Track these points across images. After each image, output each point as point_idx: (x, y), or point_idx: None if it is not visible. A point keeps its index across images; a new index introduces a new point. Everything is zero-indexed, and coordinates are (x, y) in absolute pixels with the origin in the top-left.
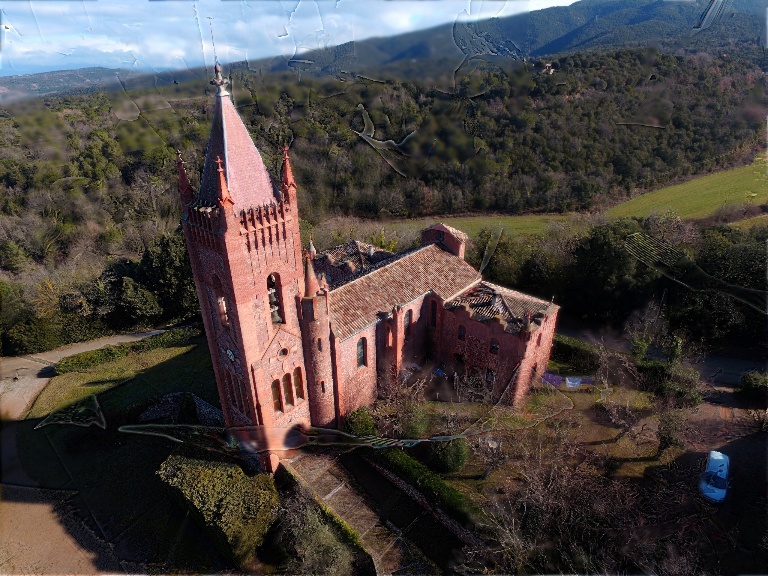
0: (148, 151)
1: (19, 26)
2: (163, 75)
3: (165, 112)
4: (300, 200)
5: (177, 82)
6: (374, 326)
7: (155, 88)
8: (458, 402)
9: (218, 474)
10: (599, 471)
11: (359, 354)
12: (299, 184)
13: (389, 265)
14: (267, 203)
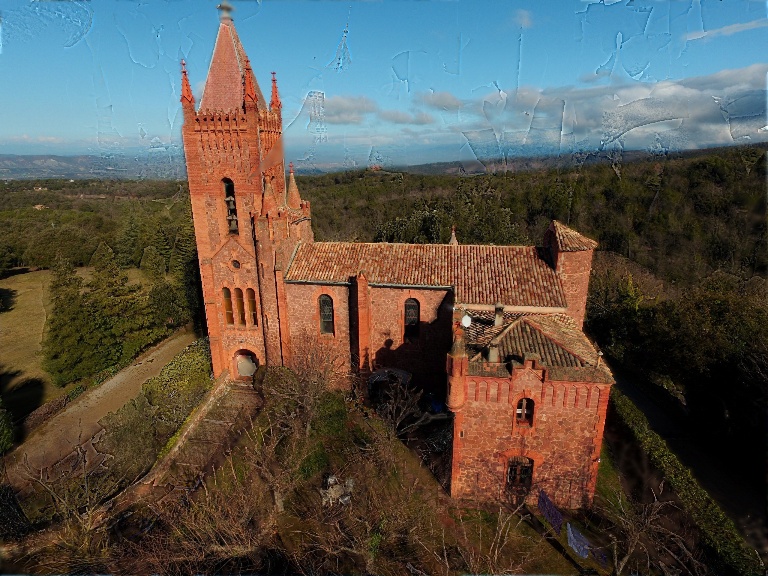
0: (480, 172)
1: (396, 65)
2: (493, 100)
3: (487, 133)
4: (590, 235)
5: (528, 113)
6: (347, 290)
7: (483, 111)
8: (405, 444)
9: (198, 358)
10: (255, 573)
11: (327, 316)
12: (590, 215)
13: (432, 245)
14: (232, 112)
